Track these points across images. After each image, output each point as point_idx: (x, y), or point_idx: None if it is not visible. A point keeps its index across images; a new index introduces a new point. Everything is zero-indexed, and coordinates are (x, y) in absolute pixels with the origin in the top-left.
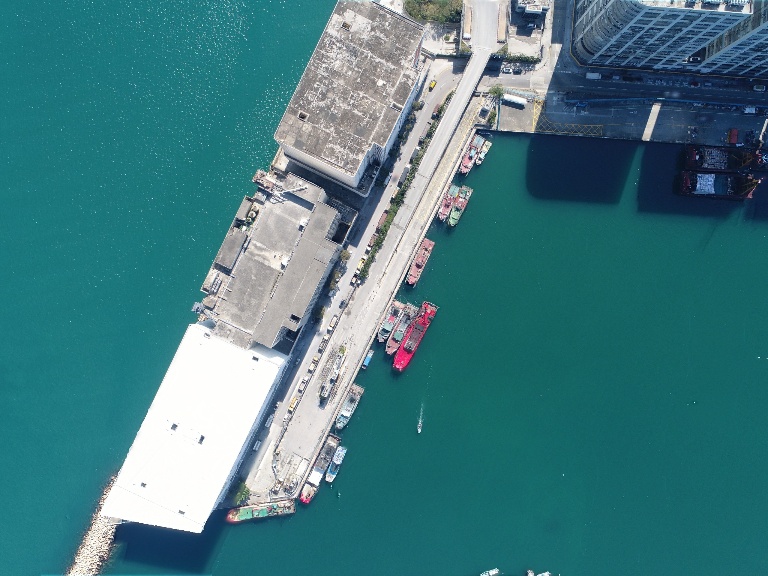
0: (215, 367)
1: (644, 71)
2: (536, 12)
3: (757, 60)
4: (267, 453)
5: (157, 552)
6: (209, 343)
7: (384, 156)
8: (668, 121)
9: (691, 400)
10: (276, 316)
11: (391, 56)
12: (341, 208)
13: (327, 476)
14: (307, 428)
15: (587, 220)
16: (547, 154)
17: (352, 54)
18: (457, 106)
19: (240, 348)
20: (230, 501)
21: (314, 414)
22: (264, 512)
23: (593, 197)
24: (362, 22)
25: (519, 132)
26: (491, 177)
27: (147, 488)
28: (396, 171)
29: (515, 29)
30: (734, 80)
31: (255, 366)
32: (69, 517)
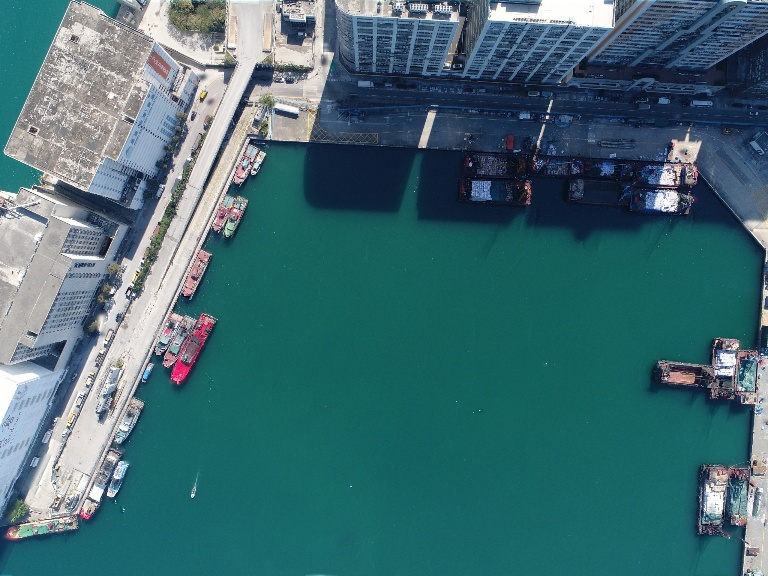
0: None
1: (417, 78)
2: (301, 21)
3: (511, 66)
4: (47, 469)
5: None
6: None
7: (141, 168)
8: (444, 128)
9: (476, 408)
10: (13, 333)
11: (121, 69)
12: (101, 221)
13: (109, 491)
14: (87, 443)
15: (367, 229)
16: (324, 163)
17: (81, 67)
18: (224, 116)
19: None
20: None
21: (94, 429)
22: (44, 529)
23: (373, 205)
24: (91, 35)
25: (294, 141)
26: (267, 187)
27: None
28: (169, 183)
29: (286, 38)
30: (509, 86)
31: None
32: None
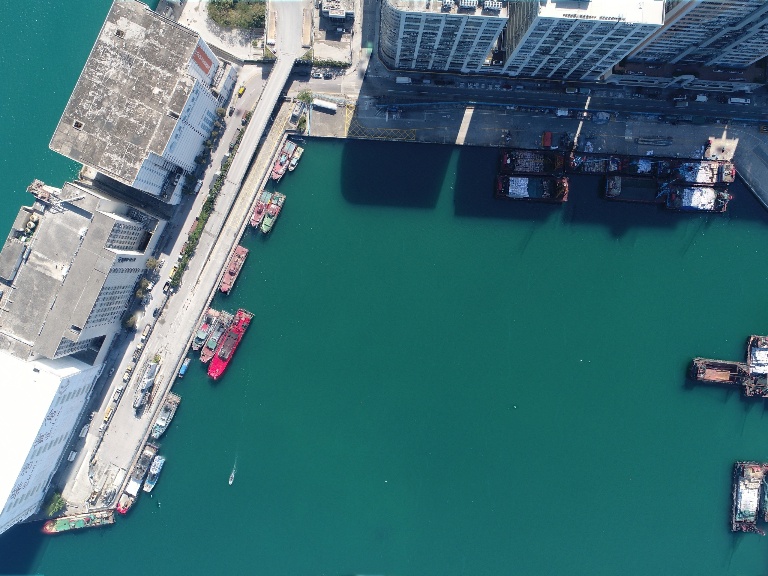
0: None
1: (455, 75)
2: (340, 17)
3: (552, 63)
4: (84, 463)
5: None
6: None
7: (182, 164)
8: (482, 125)
9: (512, 404)
10: (57, 327)
11: (166, 63)
12: (141, 216)
13: (145, 486)
14: (124, 438)
15: (403, 225)
16: (362, 159)
17: (127, 62)
18: (263, 112)
19: (21, 360)
20: None
21: (130, 424)
22: (81, 523)
23: (410, 202)
24: (136, 29)
25: (332, 137)
26: (305, 183)
27: None
28: (207, 178)
29: (324, 34)
30: (547, 83)
31: (37, 378)
32: None
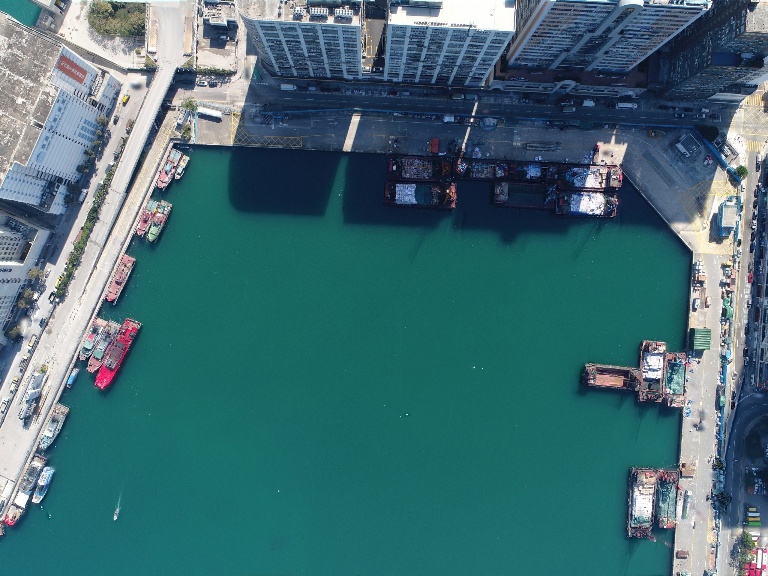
0: None
1: None
2: (221, 24)
3: (428, 69)
4: None
5: None
6: None
7: (59, 173)
8: (369, 131)
9: (404, 412)
10: None
11: (29, 73)
12: (20, 227)
13: (34, 497)
14: (12, 449)
15: (292, 233)
16: (249, 167)
17: None
18: (145, 121)
19: None
20: None
21: (18, 435)
22: None
23: (299, 209)
24: None
25: (218, 145)
26: (192, 191)
27: None
28: (92, 187)
29: (208, 41)
30: (433, 89)
31: None
32: None
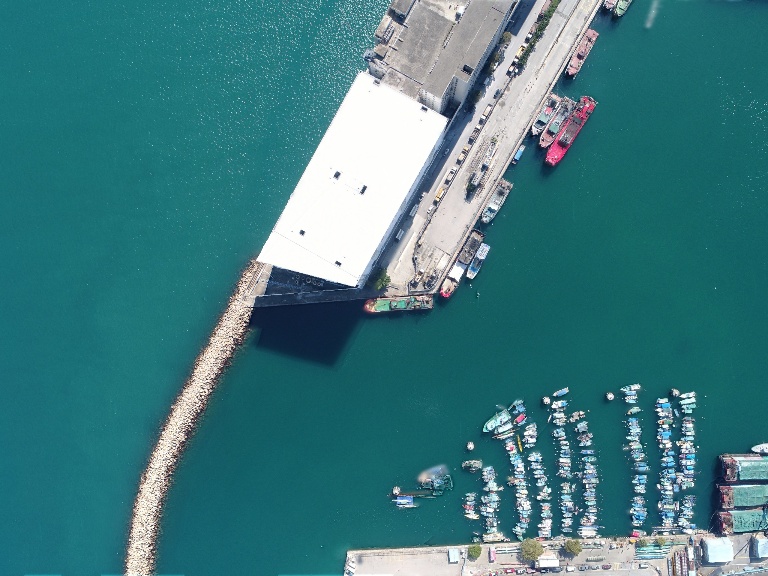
0: (383, 114)
1: None
2: None
3: None
4: (409, 245)
5: (291, 340)
6: (378, 91)
7: None
8: None
9: None
10: (448, 66)
11: None
12: None
13: (468, 272)
14: (451, 221)
15: (764, 18)
16: None
17: None
18: None
19: (409, 97)
20: (368, 291)
21: (459, 207)
22: (402, 304)
23: None
24: None
25: None
26: None
27: (305, 237)
28: None
29: None
30: None
31: (423, 117)
32: (207, 299)
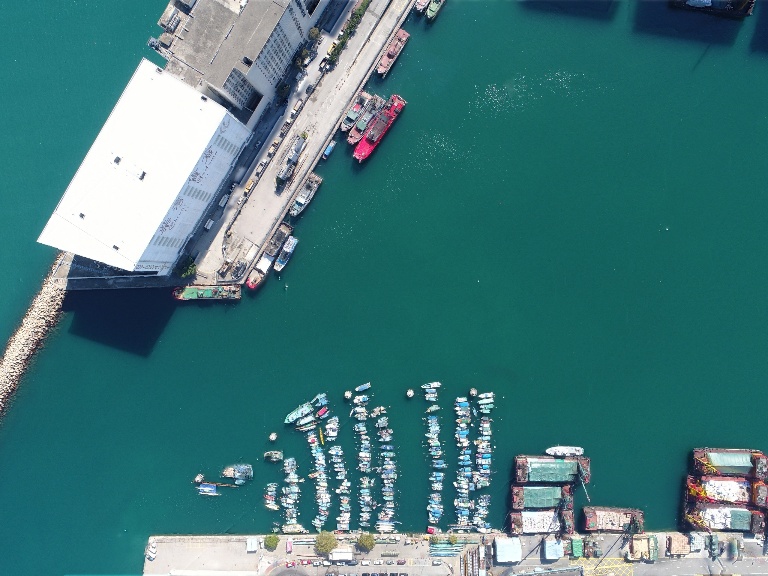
0: (163, 102)
1: None
2: None
3: None
4: (219, 234)
5: (102, 324)
6: (160, 79)
7: None
8: None
9: (664, 227)
10: (229, 57)
11: None
12: None
13: (276, 265)
14: (261, 213)
15: (572, 26)
16: None
17: None
18: None
19: (190, 86)
20: (177, 279)
21: (269, 200)
22: (209, 292)
23: (581, 3)
24: None
25: None
26: None
27: (85, 220)
28: None
29: None
30: None
31: (203, 107)
32: (22, 280)
